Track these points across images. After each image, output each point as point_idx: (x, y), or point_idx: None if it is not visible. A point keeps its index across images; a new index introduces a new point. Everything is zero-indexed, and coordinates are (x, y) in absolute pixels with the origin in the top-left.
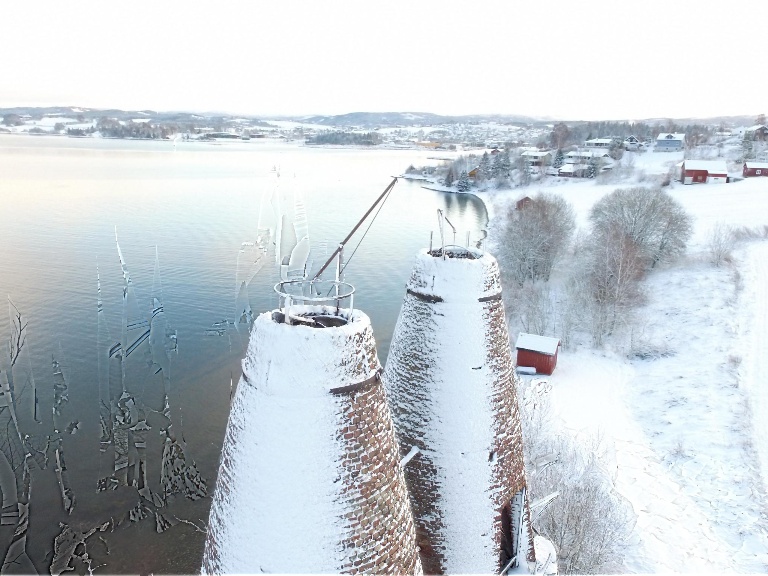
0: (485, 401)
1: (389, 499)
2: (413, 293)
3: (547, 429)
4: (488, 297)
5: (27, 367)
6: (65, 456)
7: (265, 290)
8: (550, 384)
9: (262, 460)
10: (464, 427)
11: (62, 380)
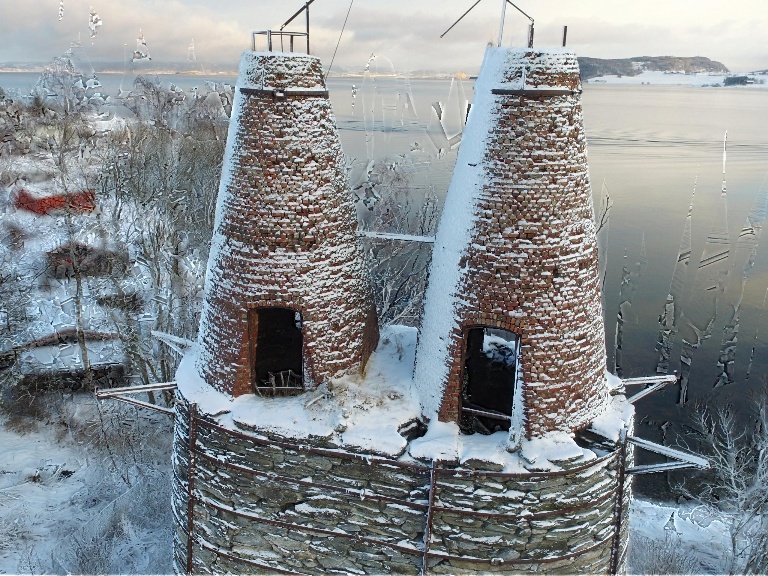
0: (470, 201)
1: (258, 178)
2: None
3: None
4: (504, 90)
5: (605, 242)
6: (623, 337)
7: None
8: None
9: None
10: (448, 221)
11: (628, 264)
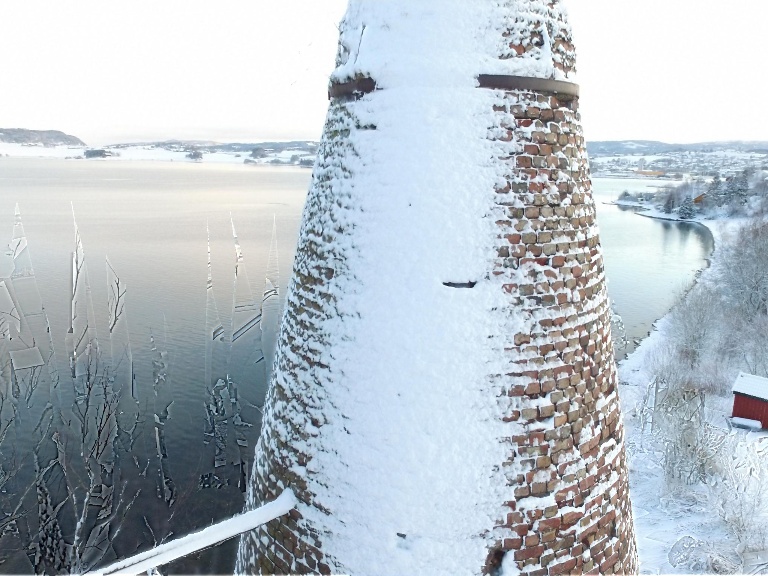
0: (480, 387)
1: None
2: None
3: None
4: (512, 77)
5: (125, 338)
6: (166, 442)
7: None
8: None
9: None
10: (405, 456)
11: (160, 357)
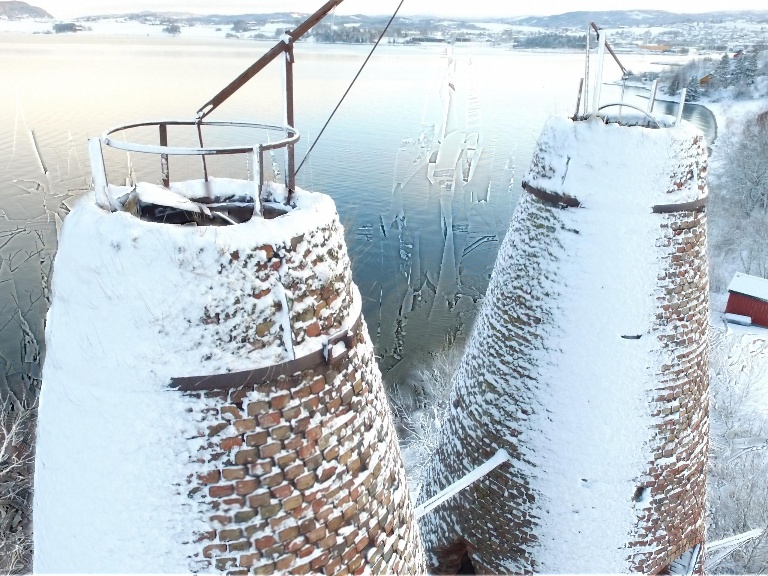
0: (640, 397)
1: None
2: (530, 188)
3: (756, 399)
4: (674, 204)
5: None
6: None
7: (422, 194)
8: None
9: (46, 502)
10: (592, 437)
11: None
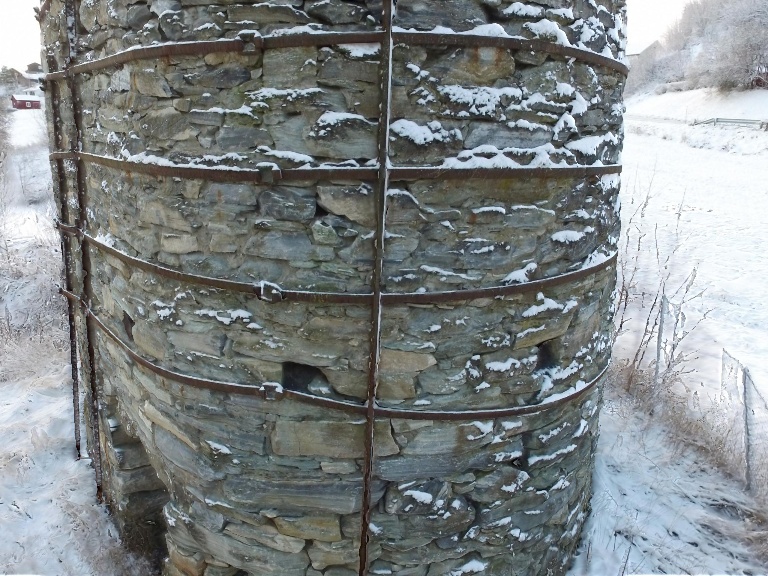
0: None
1: None
2: None
3: (12, 212)
4: None
5: None
6: None
7: None
8: (3, 149)
9: None
10: None
11: None
